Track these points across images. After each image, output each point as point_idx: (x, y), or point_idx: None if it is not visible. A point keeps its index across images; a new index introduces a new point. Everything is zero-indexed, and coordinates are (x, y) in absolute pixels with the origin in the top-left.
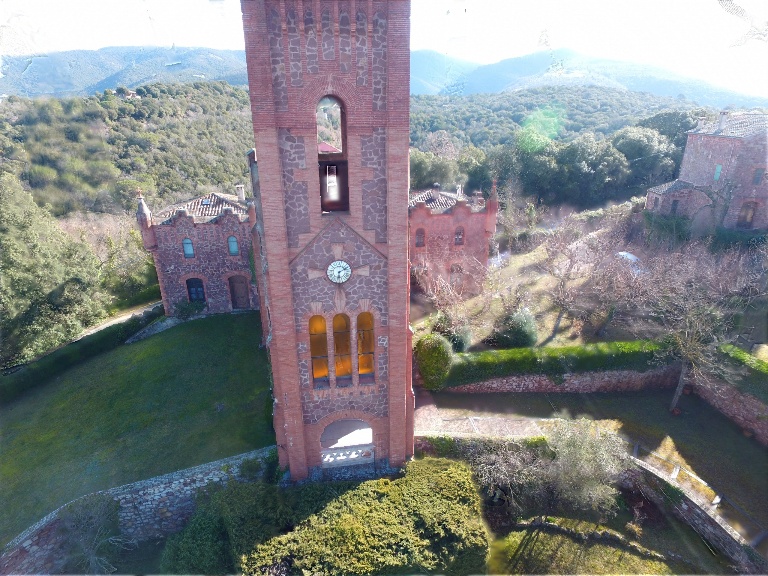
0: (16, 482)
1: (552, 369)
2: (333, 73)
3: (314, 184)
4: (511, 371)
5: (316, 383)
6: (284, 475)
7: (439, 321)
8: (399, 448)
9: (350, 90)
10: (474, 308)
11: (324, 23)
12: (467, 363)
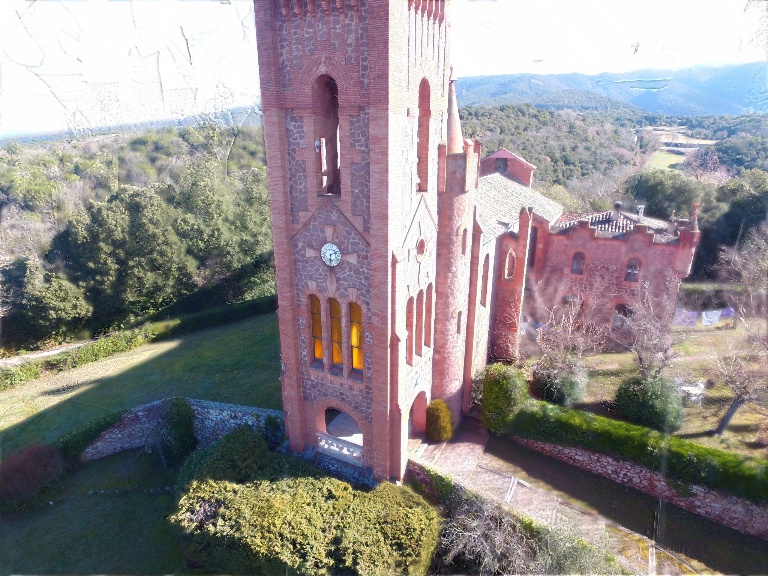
0: (173, 376)
1: (674, 470)
2: (326, 53)
3: (311, 163)
4: (607, 448)
5: (315, 363)
6: (286, 441)
7: (544, 359)
8: (382, 463)
9: (340, 69)
10: (629, 364)
11: (319, 4)
12: (542, 415)
